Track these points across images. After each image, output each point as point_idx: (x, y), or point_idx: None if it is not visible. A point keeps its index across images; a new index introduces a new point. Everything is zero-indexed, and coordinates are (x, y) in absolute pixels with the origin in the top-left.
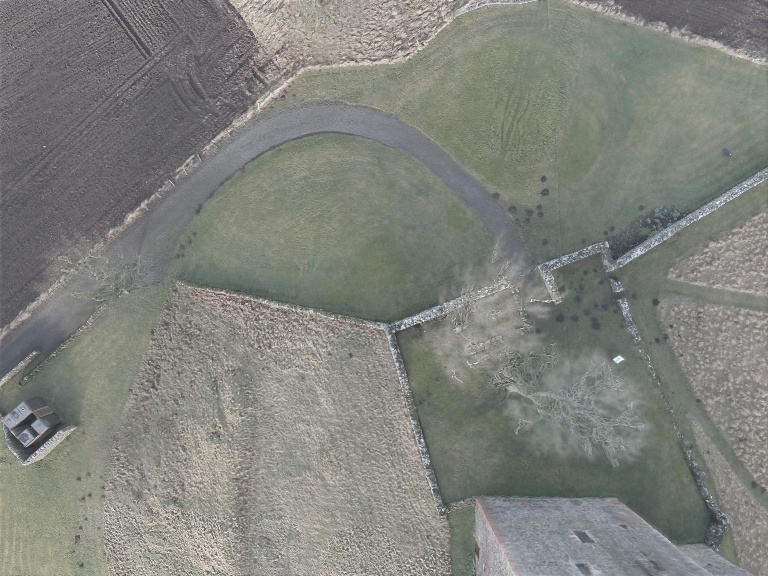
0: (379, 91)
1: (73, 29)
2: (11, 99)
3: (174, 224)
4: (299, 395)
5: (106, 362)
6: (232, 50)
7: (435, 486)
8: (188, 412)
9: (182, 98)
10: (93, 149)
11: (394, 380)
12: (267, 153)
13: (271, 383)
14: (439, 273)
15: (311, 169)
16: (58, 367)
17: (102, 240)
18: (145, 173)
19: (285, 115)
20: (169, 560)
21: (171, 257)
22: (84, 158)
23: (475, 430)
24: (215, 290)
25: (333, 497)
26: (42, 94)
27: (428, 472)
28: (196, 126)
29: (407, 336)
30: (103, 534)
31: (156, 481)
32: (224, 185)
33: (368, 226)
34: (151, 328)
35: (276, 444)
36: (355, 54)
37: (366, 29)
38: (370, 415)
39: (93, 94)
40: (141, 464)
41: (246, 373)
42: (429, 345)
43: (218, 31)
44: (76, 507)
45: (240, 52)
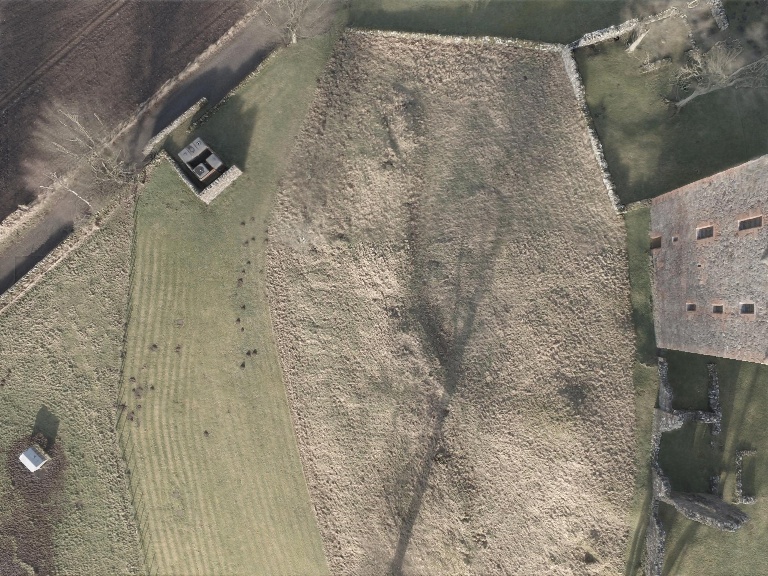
0: None
1: None
2: None
3: None
4: (471, 122)
5: (272, 110)
6: None
7: (614, 186)
8: (356, 151)
9: None
10: None
11: (570, 96)
12: None
13: (442, 115)
14: (608, 5)
15: None
16: (226, 115)
17: None
18: None
19: None
20: (333, 296)
21: (338, 8)
22: None
23: (648, 141)
24: (386, 31)
25: (510, 207)
26: None
27: (607, 174)
28: None
29: (583, 55)
30: (265, 277)
31: (321, 220)
32: None
33: None
34: (317, 77)
35: (446, 172)
36: None
37: None
38: (546, 130)
39: None
40: (305, 207)
41: (418, 105)
42: (604, 63)
43: None
44: (239, 251)
45: None
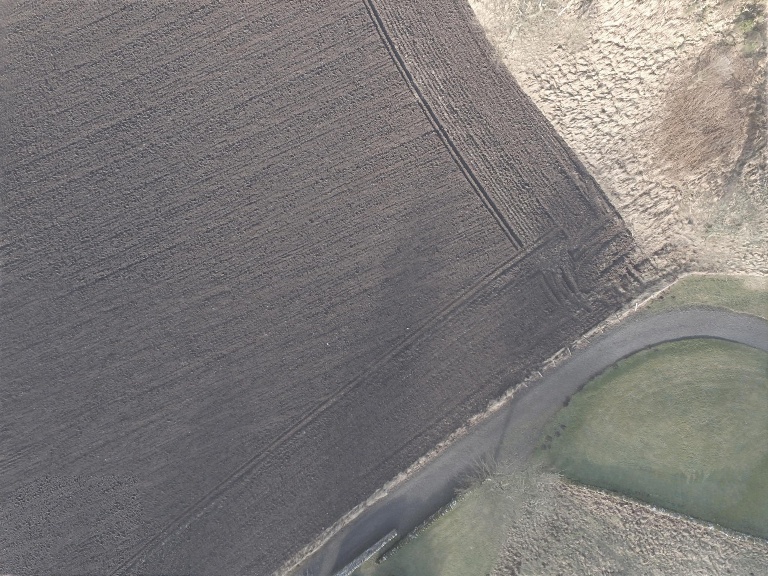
0: (767, 302)
1: (444, 216)
2: (376, 280)
3: (540, 414)
4: None
5: (464, 545)
6: (608, 248)
7: None
8: None
9: (553, 291)
10: (458, 334)
11: None
12: (642, 352)
13: None
14: None
15: (694, 374)
16: (415, 547)
17: (464, 425)
18: (511, 361)
19: (663, 316)
20: None
21: (536, 447)
22: (448, 342)
23: None
24: (593, 490)
25: None
26: (408, 278)
27: None
28: (567, 319)
29: None
30: None
31: None
32: (595, 380)
33: (762, 441)
34: None
35: None
36: (745, 264)
37: (759, 241)
38: None
39: (460, 281)
40: None
41: None
42: None
43: (595, 228)
44: None
45: (616, 250)
